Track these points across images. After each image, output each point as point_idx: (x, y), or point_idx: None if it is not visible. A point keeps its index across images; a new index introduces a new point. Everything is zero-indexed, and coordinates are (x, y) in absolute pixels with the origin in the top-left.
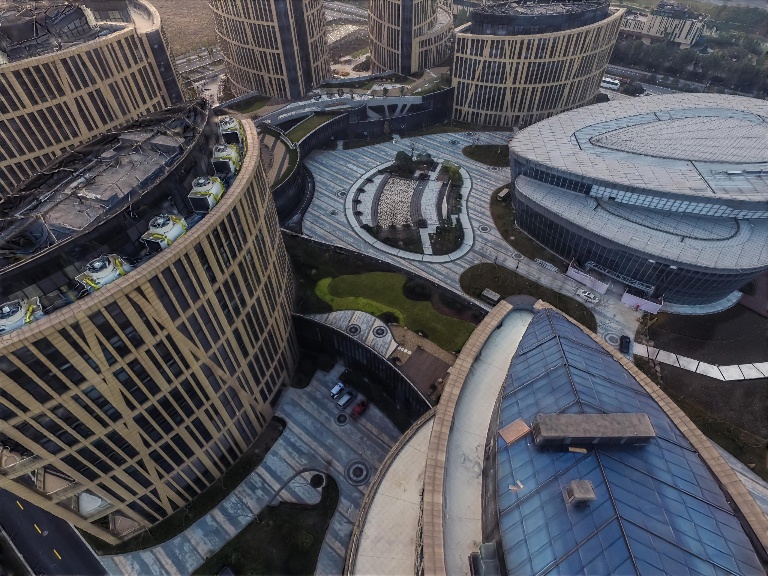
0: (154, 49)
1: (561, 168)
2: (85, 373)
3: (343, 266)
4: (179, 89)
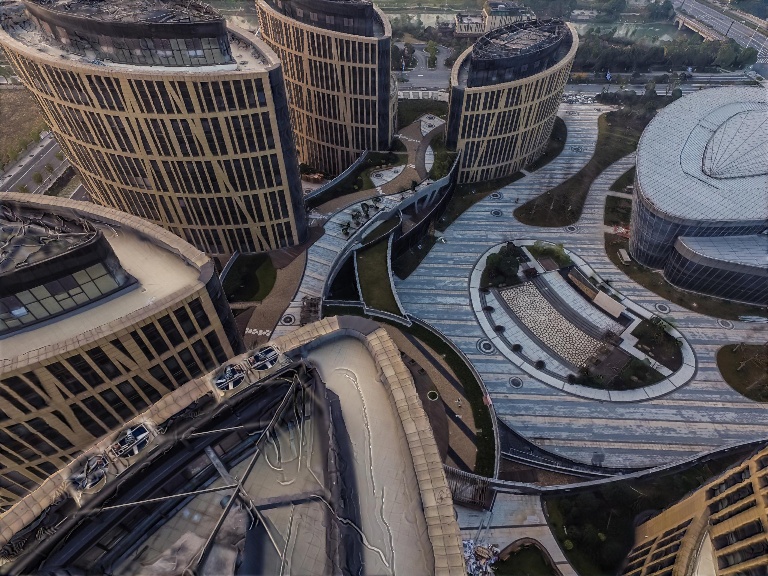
0: (216, 302)
1: (742, 219)
2: None
3: None
4: (241, 338)
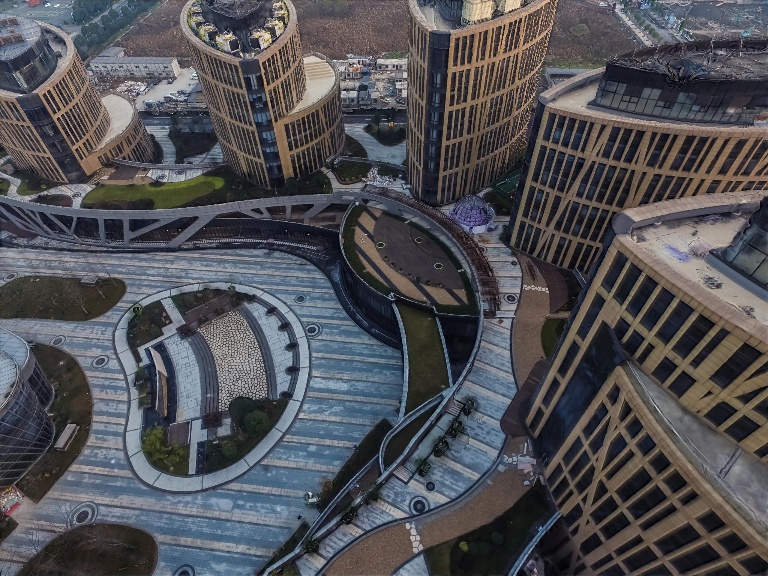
0: None
1: None
2: None
3: None
4: (526, 182)
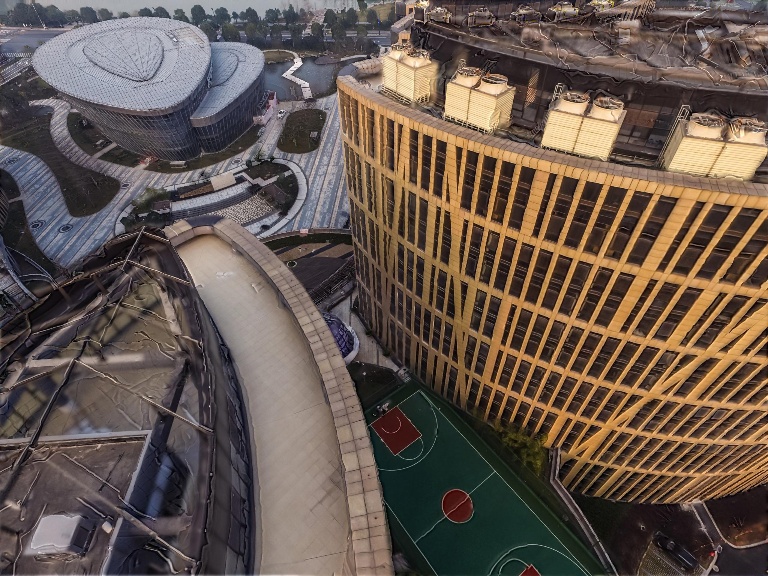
0: None
1: (198, 82)
2: None
3: None
4: None
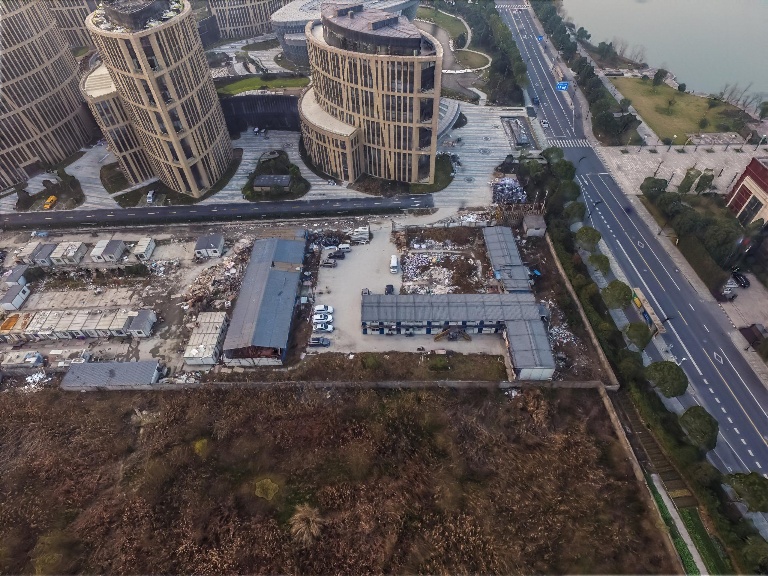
0: None
1: (303, 20)
2: (182, 53)
3: (224, 83)
4: None
